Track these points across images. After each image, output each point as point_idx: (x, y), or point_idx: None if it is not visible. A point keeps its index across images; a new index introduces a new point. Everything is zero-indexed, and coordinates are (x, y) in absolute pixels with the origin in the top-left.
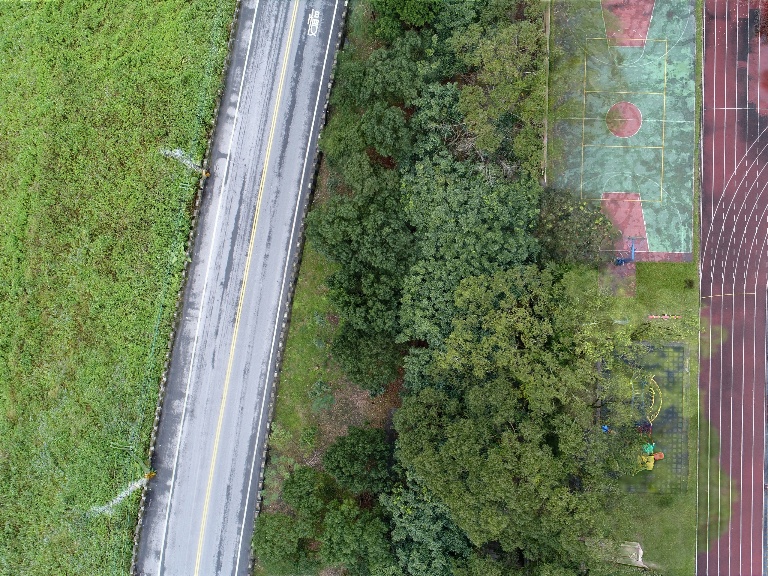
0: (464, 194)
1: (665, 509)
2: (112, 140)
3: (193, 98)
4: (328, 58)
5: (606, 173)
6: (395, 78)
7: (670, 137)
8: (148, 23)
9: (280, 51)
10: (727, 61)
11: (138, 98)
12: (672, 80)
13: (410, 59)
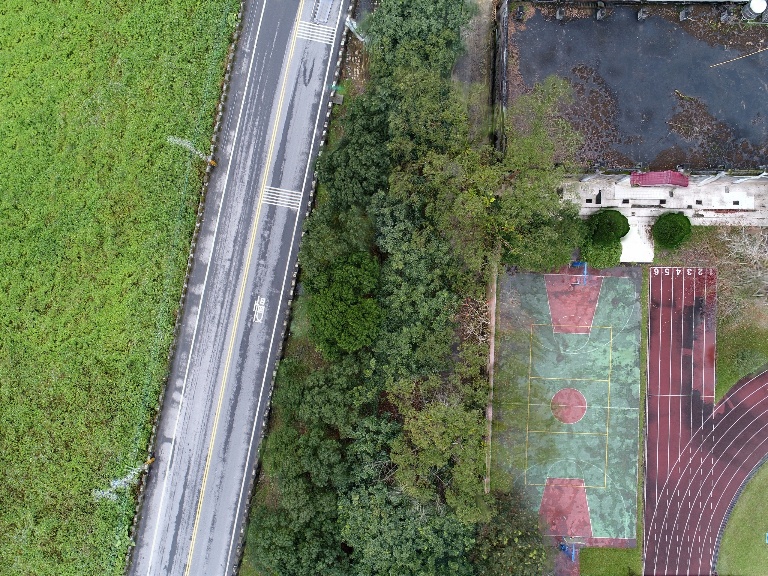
0: (399, 526)
1: None
2: (58, 423)
3: (139, 381)
4: (274, 344)
5: (550, 459)
6: (330, 414)
7: (614, 424)
8: (95, 307)
9: (226, 337)
10: (672, 348)
11: (84, 381)
12: (617, 367)
13: (346, 390)
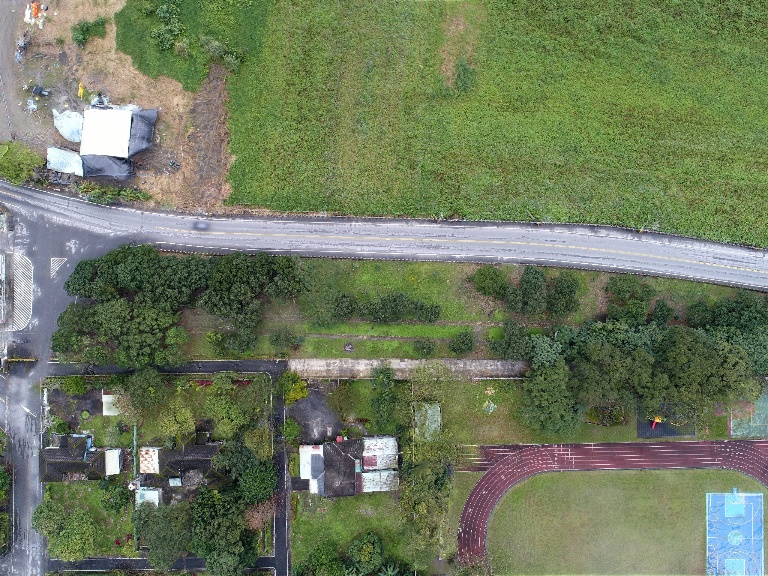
0: (767, 347)
1: (631, 430)
2: None
3: None
4: None
5: (762, 403)
6: None
7: None
8: None
9: None
10: None
11: None
12: None
13: None
